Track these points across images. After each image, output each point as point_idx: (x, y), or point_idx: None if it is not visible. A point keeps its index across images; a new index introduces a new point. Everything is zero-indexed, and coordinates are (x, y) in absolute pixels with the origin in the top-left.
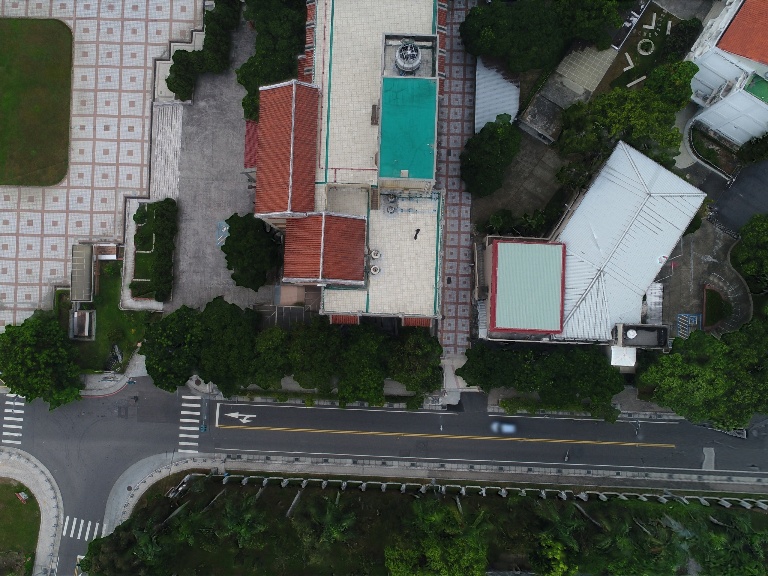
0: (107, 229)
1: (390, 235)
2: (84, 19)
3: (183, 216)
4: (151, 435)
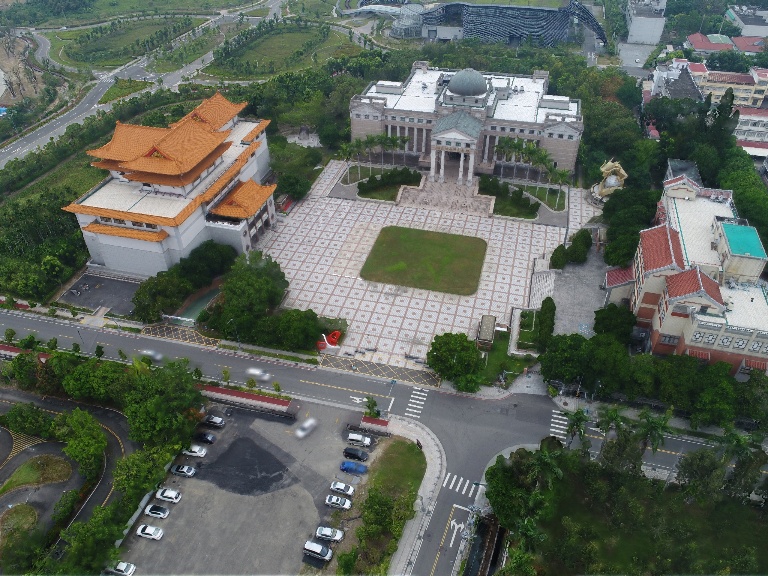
0: (499, 319)
1: (734, 298)
2: (494, 240)
3: (555, 317)
4: (526, 430)
